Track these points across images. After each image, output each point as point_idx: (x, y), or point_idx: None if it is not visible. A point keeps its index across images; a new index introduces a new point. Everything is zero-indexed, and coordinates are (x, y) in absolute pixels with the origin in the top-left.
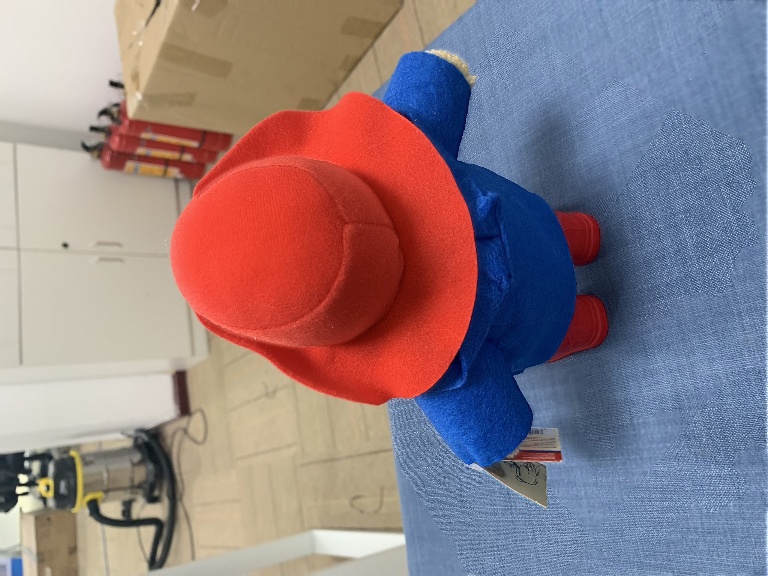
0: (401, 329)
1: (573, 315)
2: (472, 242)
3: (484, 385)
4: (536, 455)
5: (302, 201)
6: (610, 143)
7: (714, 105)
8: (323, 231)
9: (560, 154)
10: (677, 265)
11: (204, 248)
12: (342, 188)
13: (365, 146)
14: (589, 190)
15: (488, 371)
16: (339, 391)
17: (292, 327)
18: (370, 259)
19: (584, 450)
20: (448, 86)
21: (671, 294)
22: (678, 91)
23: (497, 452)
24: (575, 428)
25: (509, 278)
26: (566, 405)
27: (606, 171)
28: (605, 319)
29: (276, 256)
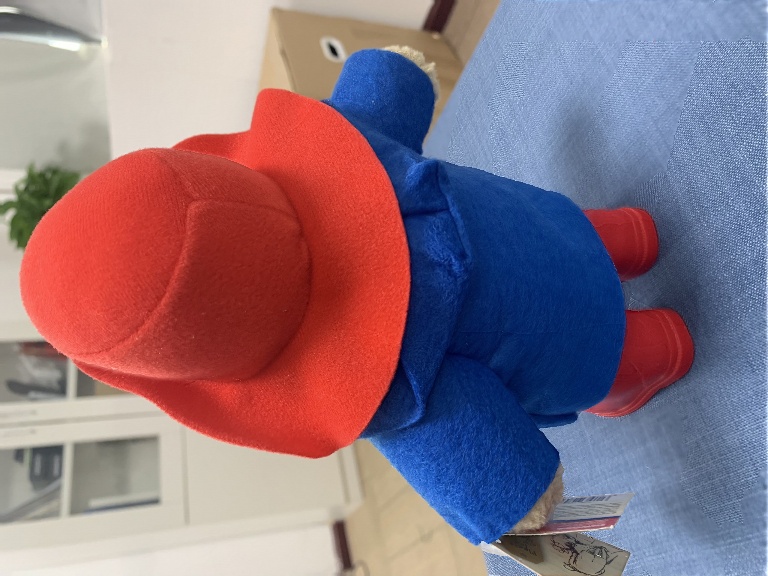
0: (317, 343)
1: (626, 328)
2: (396, 215)
3: (460, 415)
4: (579, 524)
5: (134, 180)
6: (641, 114)
7: (751, 15)
8: (157, 209)
9: (590, 150)
10: (760, 232)
11: (33, 258)
12: (198, 165)
13: (270, 139)
14: (630, 178)
15: (464, 395)
16: (248, 438)
17: (135, 340)
18: (234, 242)
19: (703, 531)
20: (391, 74)
21: (763, 274)
22: (703, 20)
23: (501, 517)
24: (684, 499)
25: (463, 258)
26: (665, 468)
27: (644, 148)
28: (686, 334)
29: (95, 246)
